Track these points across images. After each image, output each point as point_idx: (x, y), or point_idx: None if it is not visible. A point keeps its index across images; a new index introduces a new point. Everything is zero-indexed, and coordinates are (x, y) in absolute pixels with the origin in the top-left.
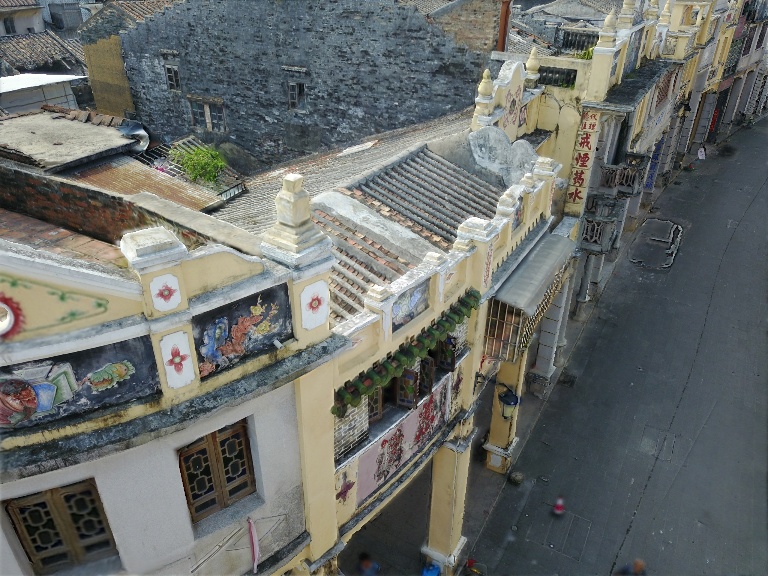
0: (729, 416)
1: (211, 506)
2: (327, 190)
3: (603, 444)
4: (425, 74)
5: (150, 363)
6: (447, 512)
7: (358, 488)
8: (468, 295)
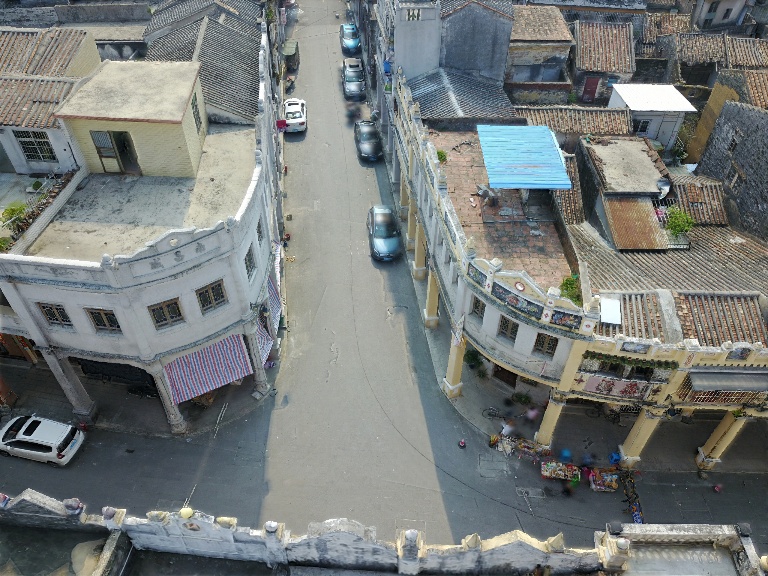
0: None
1: (540, 351)
2: (677, 287)
3: None
4: None
5: (541, 312)
6: (633, 437)
7: (586, 385)
8: (673, 363)
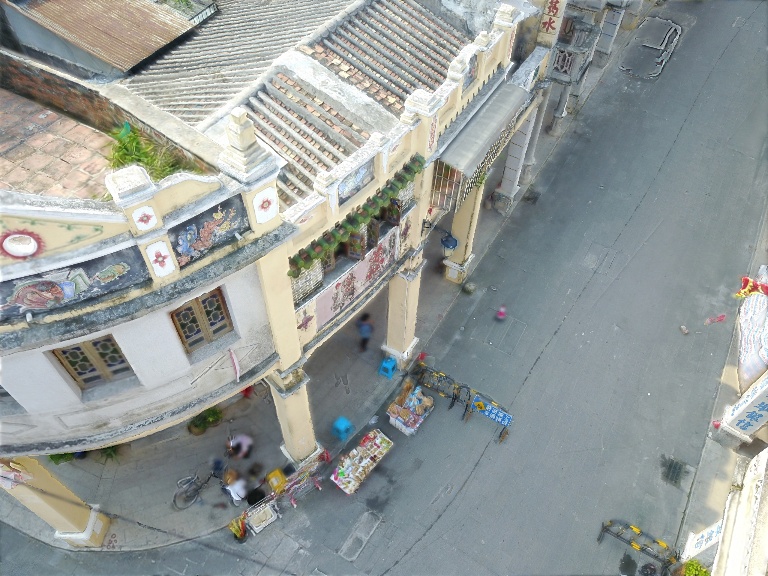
0: (670, 234)
1: (200, 342)
2: (291, 43)
3: (551, 258)
4: None
5: (140, 262)
6: (401, 322)
7: (317, 318)
8: (413, 161)
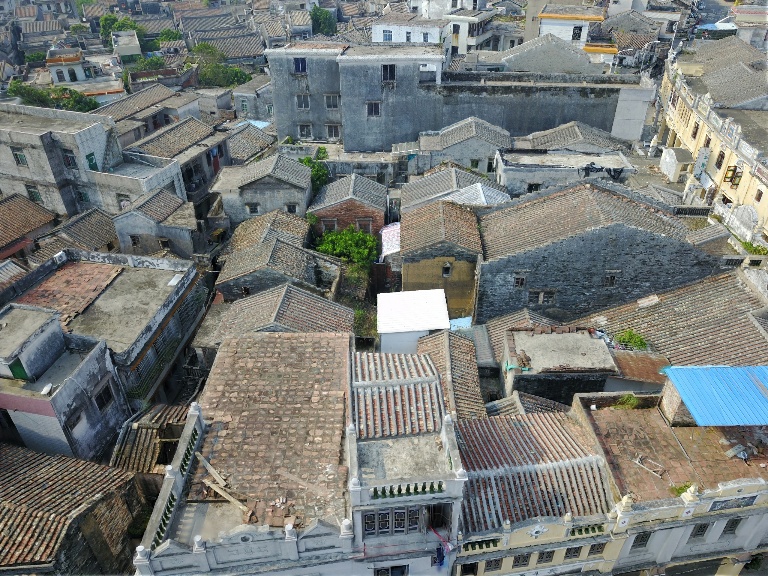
0: None
1: None
2: (767, 351)
3: None
4: (688, 266)
5: None
6: None
7: None
8: None
